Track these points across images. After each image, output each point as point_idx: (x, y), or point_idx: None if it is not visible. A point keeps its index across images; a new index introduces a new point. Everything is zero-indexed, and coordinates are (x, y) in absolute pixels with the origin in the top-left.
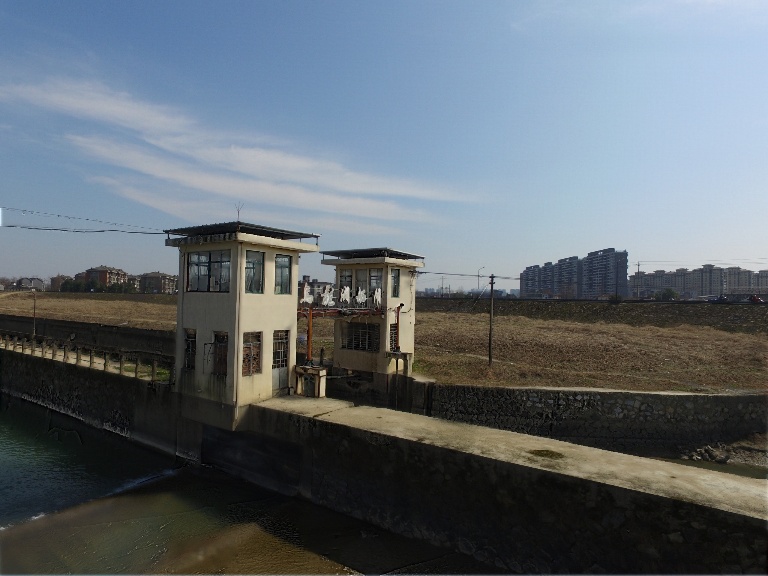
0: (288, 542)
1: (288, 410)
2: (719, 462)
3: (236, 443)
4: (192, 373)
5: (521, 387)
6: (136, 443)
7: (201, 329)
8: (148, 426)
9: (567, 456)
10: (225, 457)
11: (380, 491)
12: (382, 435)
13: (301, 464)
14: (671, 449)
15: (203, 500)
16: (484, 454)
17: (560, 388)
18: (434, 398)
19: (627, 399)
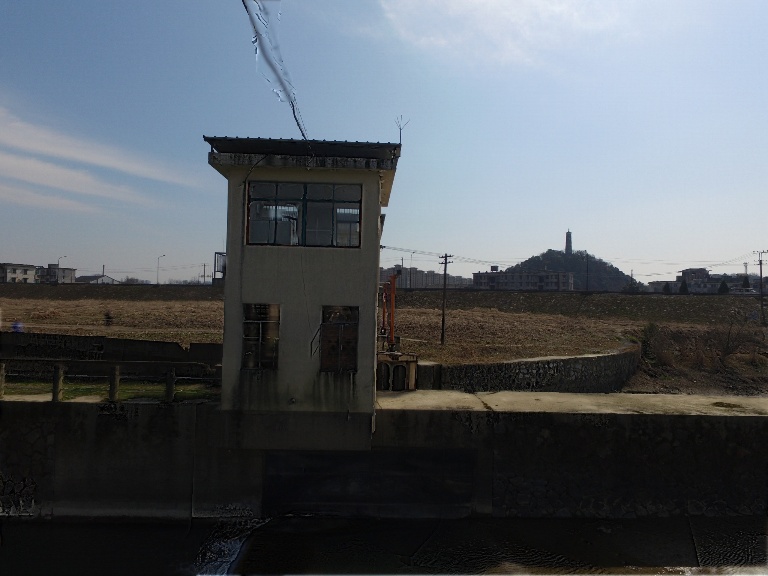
0: (573, 568)
1: (442, 407)
2: None
3: (347, 469)
4: (271, 375)
5: (512, 361)
6: (61, 521)
7: (293, 304)
8: (102, 483)
9: (738, 404)
10: (321, 495)
11: (595, 478)
12: (598, 415)
13: (475, 473)
14: None
15: (374, 562)
16: (708, 413)
17: (535, 359)
18: (444, 381)
19: (576, 363)
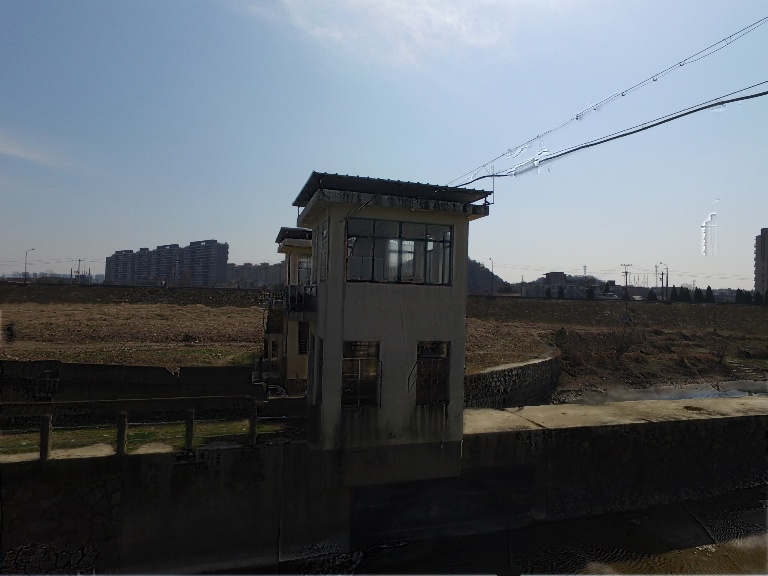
0: (637, 559)
1: (506, 429)
2: (563, 402)
3: (429, 495)
4: (372, 411)
5: None
6: None
7: (392, 340)
8: (179, 540)
9: None
10: (406, 522)
11: (620, 478)
12: (623, 425)
13: (534, 485)
14: (542, 400)
15: None
16: None
17: (500, 367)
18: None
19: (529, 369)
